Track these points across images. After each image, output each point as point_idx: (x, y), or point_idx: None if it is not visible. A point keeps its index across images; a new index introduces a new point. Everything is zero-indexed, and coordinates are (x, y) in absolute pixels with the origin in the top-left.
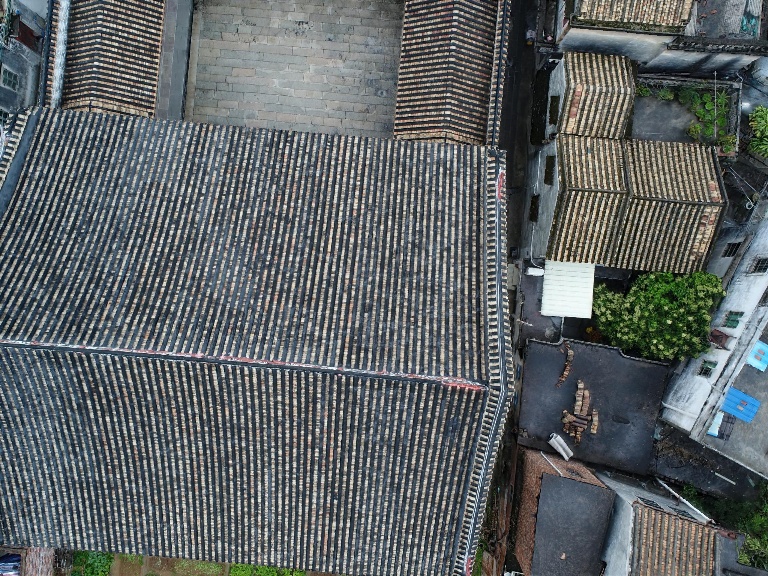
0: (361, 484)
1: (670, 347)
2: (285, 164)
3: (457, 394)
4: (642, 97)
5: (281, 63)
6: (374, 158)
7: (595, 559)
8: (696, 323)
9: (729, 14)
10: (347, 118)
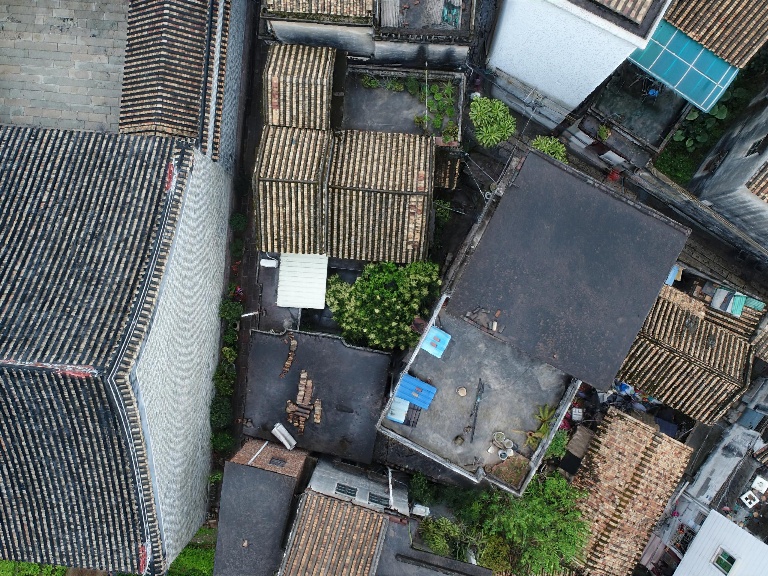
0: (42, 474)
1: (388, 336)
2: None
3: (93, 382)
4: (374, 89)
5: (46, 59)
6: (75, 151)
7: (277, 546)
8: (409, 312)
9: (431, 5)
10: (112, 113)
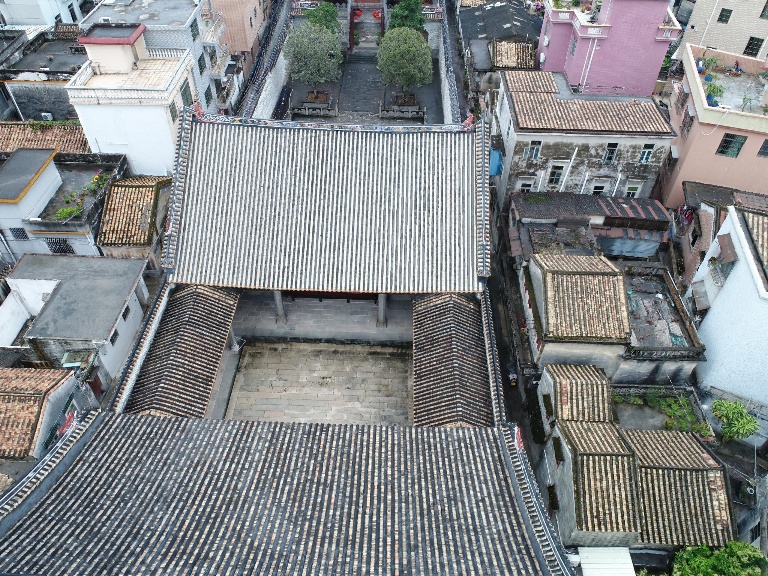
0: None
1: None
2: (322, 446)
3: None
4: (617, 404)
5: (307, 406)
6: (401, 439)
7: None
8: None
9: (659, 336)
10: None
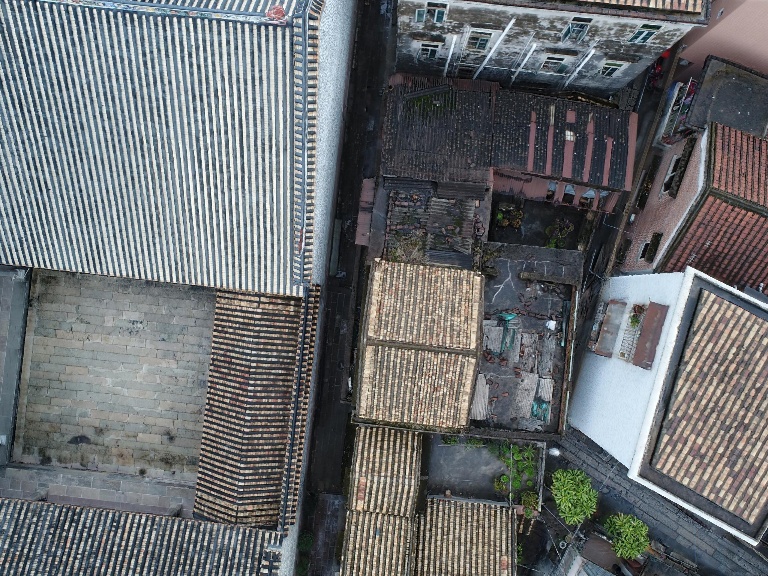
0: None
1: None
2: (67, 550)
3: None
4: None
5: (115, 362)
6: (158, 543)
7: None
8: None
9: (520, 398)
10: (179, 419)
